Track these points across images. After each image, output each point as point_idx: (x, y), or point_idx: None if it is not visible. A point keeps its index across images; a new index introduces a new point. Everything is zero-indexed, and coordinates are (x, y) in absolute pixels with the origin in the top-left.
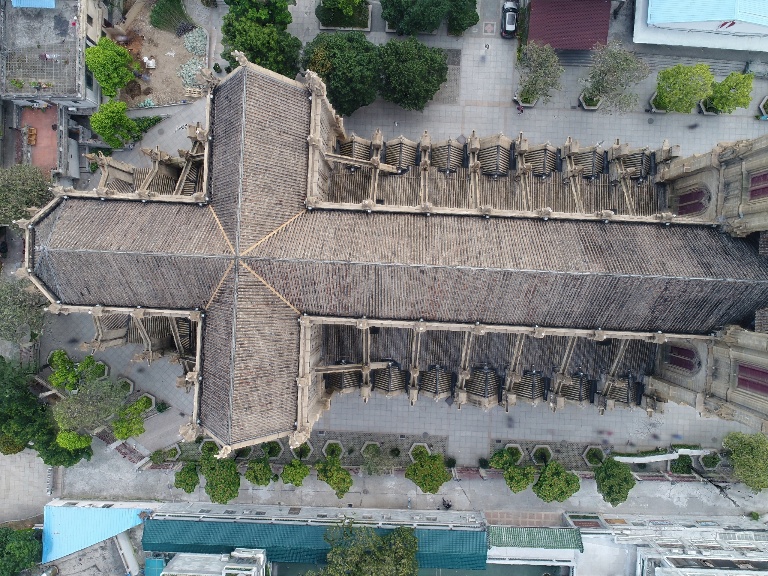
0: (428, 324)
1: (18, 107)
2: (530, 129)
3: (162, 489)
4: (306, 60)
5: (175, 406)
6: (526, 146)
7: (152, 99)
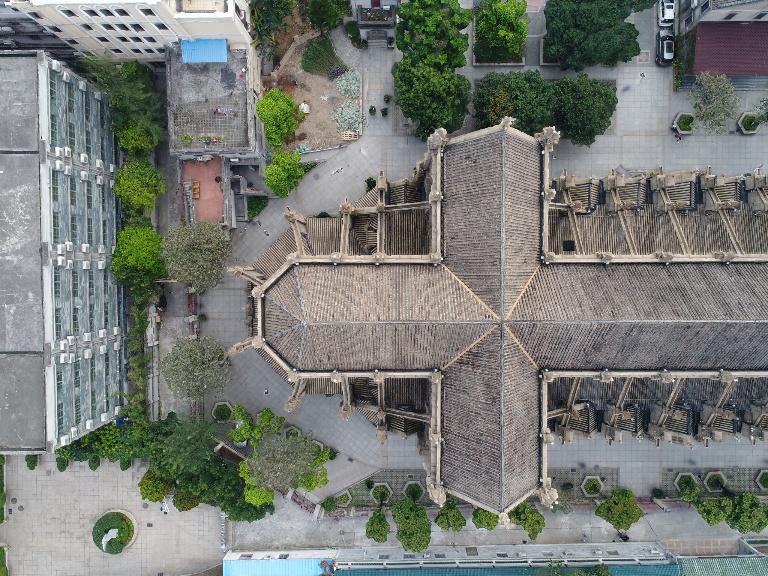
0: (672, 374)
1: (180, 161)
2: (689, 156)
3: (334, 536)
4: (481, 102)
5: (343, 452)
6: (723, 181)
7: (306, 144)
